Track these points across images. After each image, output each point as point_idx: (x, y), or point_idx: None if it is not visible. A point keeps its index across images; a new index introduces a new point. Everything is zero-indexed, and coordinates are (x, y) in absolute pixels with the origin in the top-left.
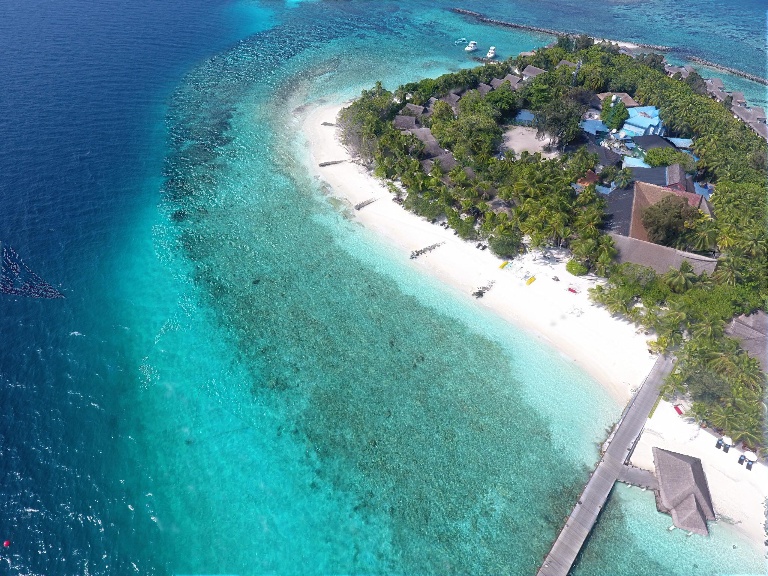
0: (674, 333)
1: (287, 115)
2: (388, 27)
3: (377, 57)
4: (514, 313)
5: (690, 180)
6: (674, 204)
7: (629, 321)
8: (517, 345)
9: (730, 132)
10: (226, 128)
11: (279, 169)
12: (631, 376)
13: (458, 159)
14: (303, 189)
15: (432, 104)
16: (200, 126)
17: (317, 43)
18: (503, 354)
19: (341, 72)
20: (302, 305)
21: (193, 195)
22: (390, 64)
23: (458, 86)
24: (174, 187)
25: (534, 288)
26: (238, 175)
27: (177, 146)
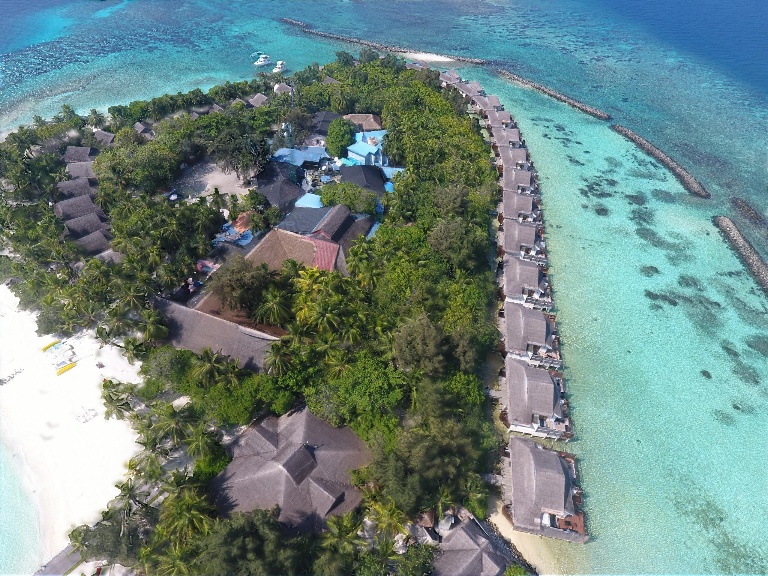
0: (151, 453)
1: None
2: (192, 39)
3: (146, 73)
4: (12, 418)
5: (363, 222)
6: (229, 269)
7: None
8: None
9: (446, 161)
10: None
11: None
12: (88, 515)
13: None
14: None
15: None
16: None
17: (90, 57)
18: None
19: (85, 91)
20: None
21: None
22: (154, 81)
23: (178, 109)
24: None
25: (62, 380)
26: None
27: None
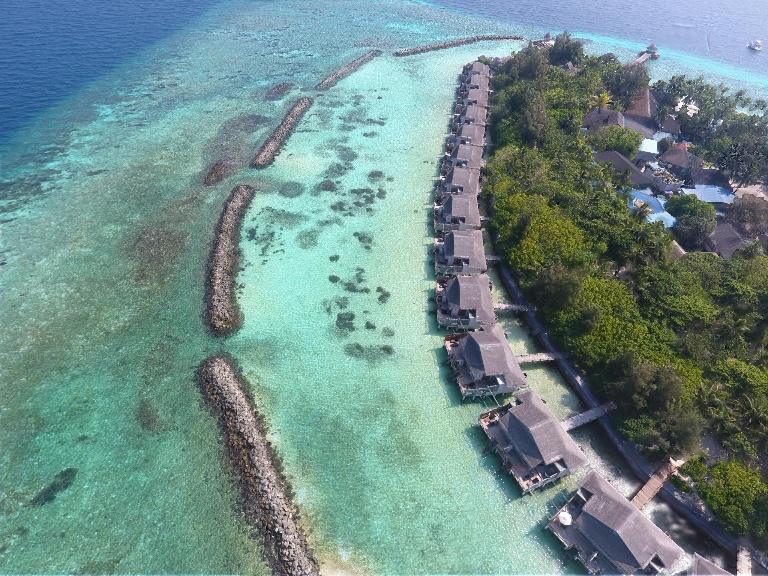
0: None
1: None
2: None
3: None
4: None
5: None
6: None
7: None
8: None
9: None
10: None
11: None
12: None
13: None
14: None
15: None
16: None
17: None
18: None
19: None
20: None
21: None
22: None
23: None
24: None
25: (681, 103)
26: None
27: None
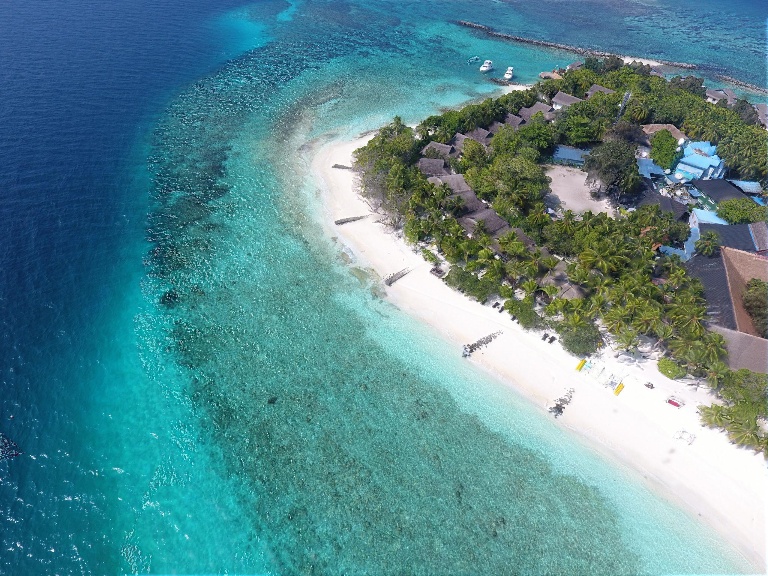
0: None
1: (291, 155)
2: (392, 43)
3: (384, 79)
4: (606, 439)
5: None
6: None
7: (756, 451)
8: (620, 491)
9: None
10: (221, 173)
11: (288, 229)
12: None
13: (501, 215)
14: (319, 257)
15: (459, 141)
16: (190, 171)
17: (316, 63)
18: (605, 507)
19: (347, 98)
20: (335, 436)
21: (185, 269)
22: (400, 88)
23: (486, 119)
24: (161, 257)
25: (625, 400)
26: (239, 238)
27: (163, 199)
